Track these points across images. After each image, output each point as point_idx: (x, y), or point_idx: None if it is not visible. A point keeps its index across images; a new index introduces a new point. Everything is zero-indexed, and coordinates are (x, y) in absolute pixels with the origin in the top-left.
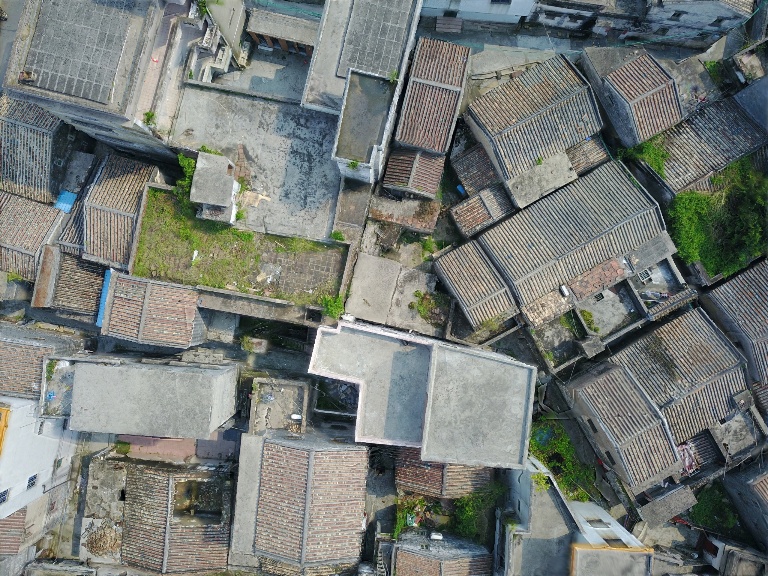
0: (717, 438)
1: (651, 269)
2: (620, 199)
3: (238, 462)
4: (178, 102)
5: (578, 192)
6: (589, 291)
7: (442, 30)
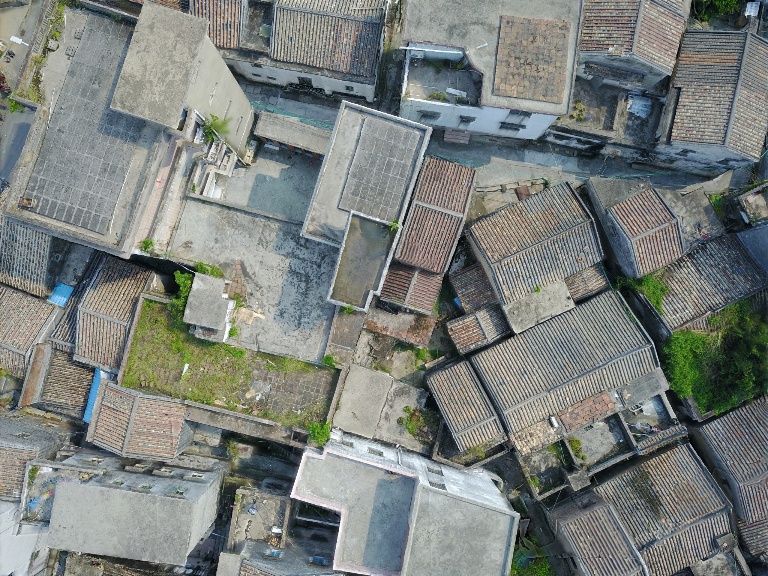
0: (698, 575)
1: (642, 403)
2: (616, 333)
3: (216, 562)
4: (179, 213)
5: (574, 321)
6: (579, 423)
7: (450, 140)
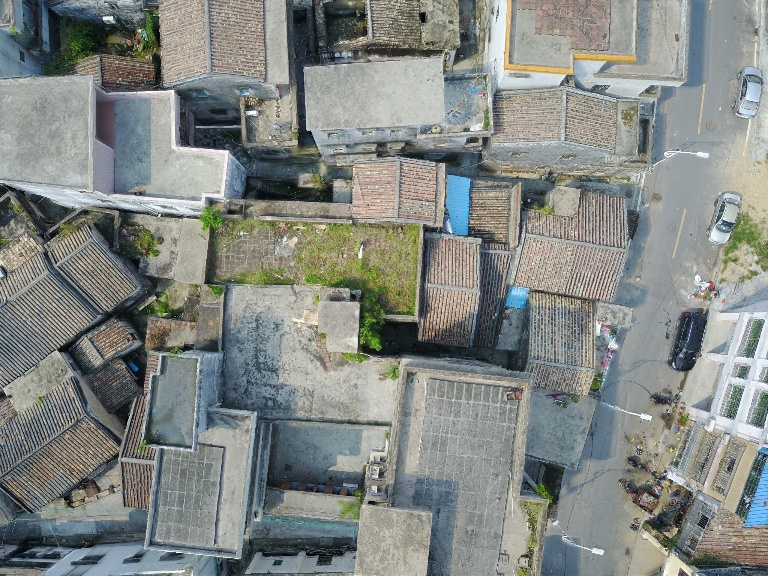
0: None
1: None
2: None
3: None
4: None
5: (2, 374)
6: None
7: None
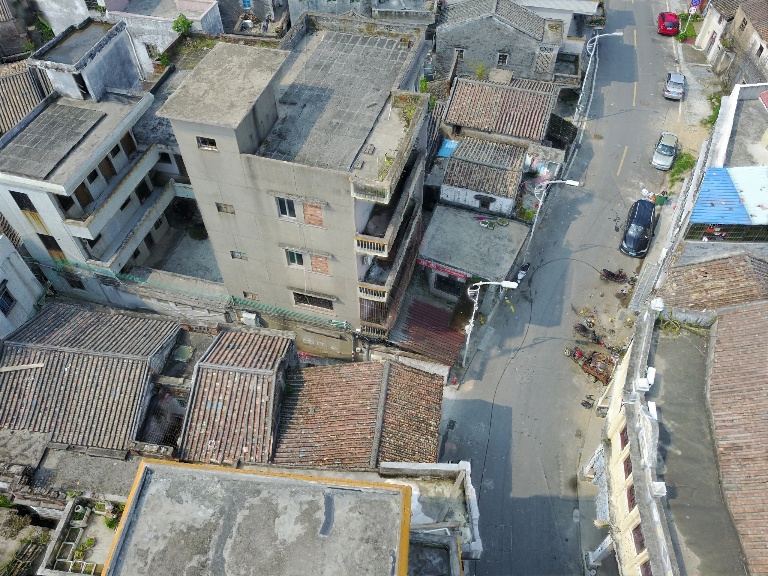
0: None
1: None
2: None
3: None
4: None
5: None
6: None
7: None
